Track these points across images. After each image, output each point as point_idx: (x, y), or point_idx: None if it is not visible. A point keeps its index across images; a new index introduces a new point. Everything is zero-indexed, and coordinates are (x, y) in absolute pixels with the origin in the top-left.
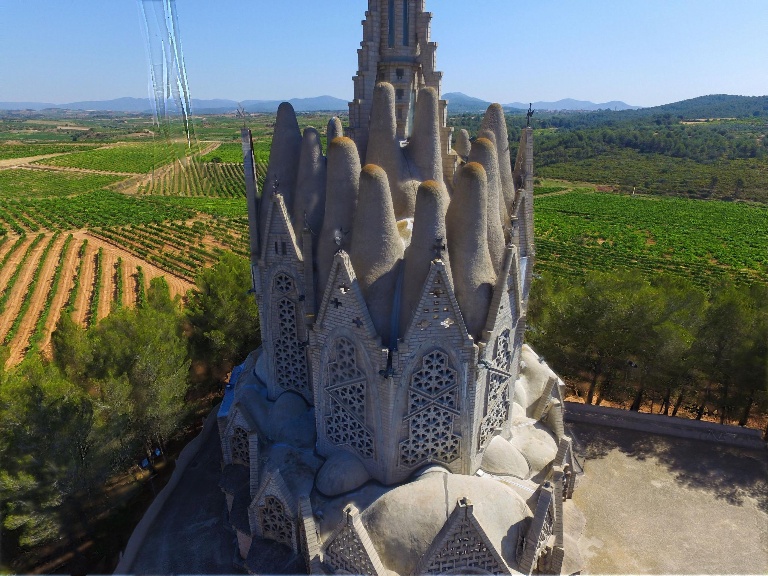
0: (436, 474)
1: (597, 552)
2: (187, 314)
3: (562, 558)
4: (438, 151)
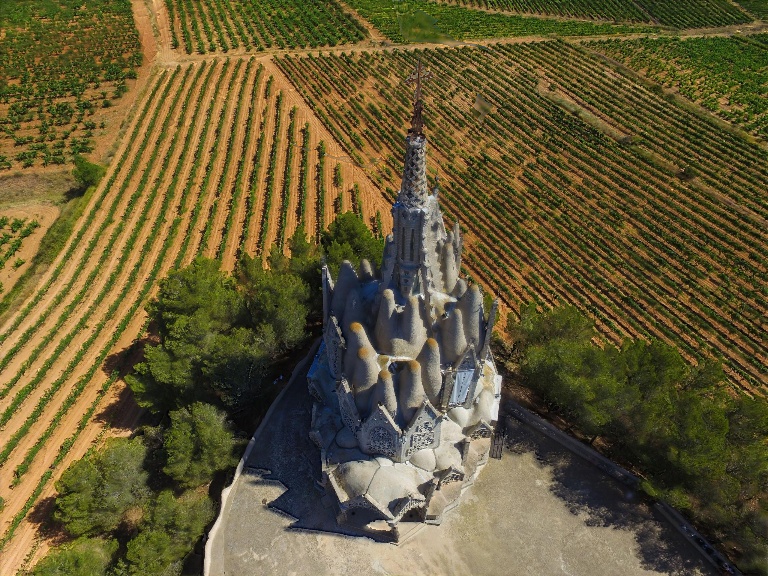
0: (376, 466)
1: (472, 503)
2: (314, 263)
3: (426, 511)
4: (414, 328)
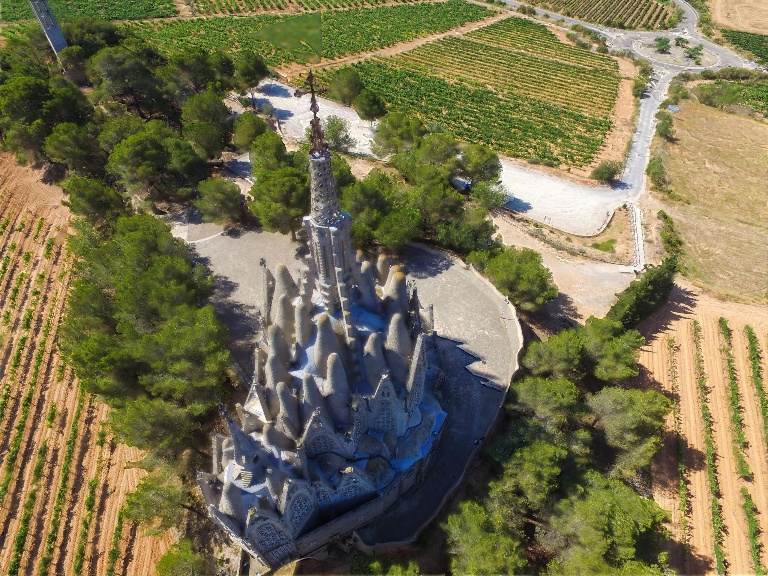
0: None
1: None
2: None
3: None
4: None
